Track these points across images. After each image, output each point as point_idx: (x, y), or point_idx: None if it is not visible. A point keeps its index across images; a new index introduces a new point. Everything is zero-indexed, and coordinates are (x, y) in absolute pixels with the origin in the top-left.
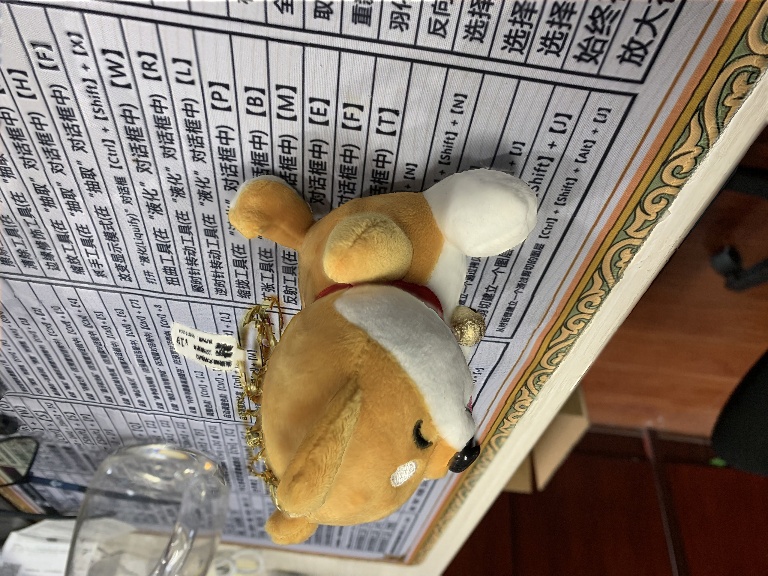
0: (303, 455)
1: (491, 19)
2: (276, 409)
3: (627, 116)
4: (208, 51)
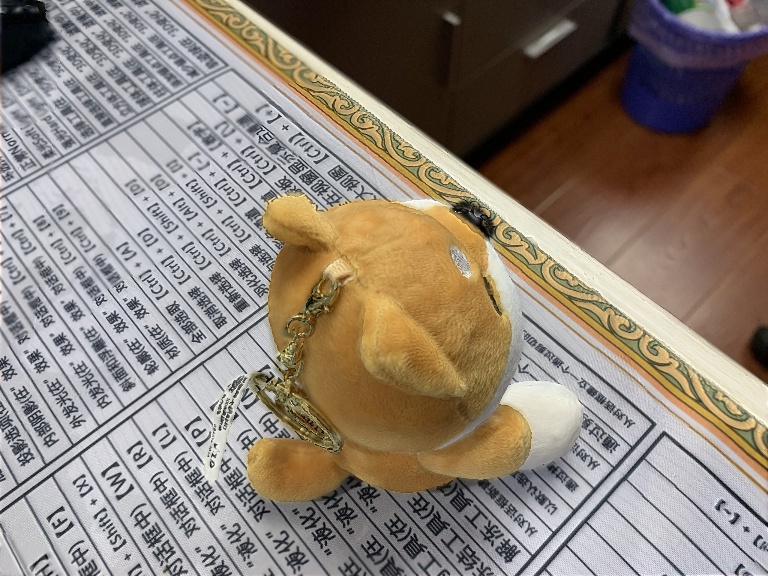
0: None
1: None
2: None
3: None
4: (172, 405)
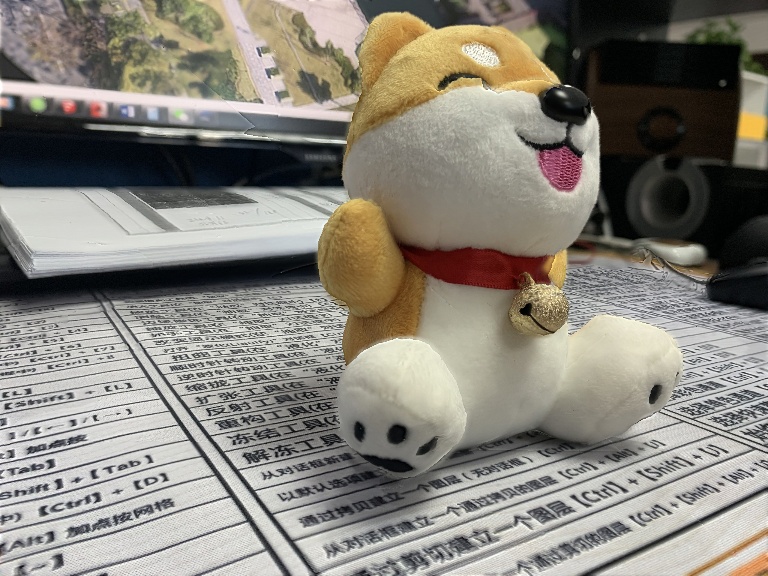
0: None
1: None
2: None
3: None
4: None
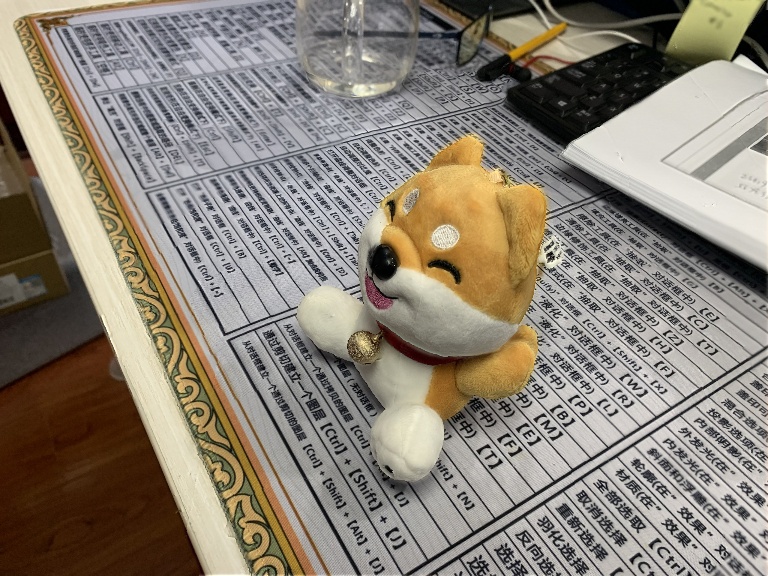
0: None
1: (505, 568)
2: None
3: None
4: (608, 429)
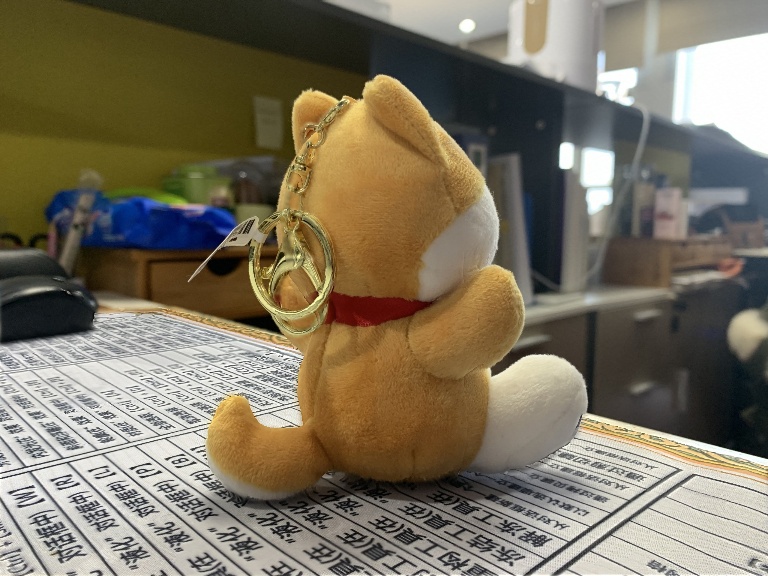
0: None
1: None
2: None
3: None
4: None
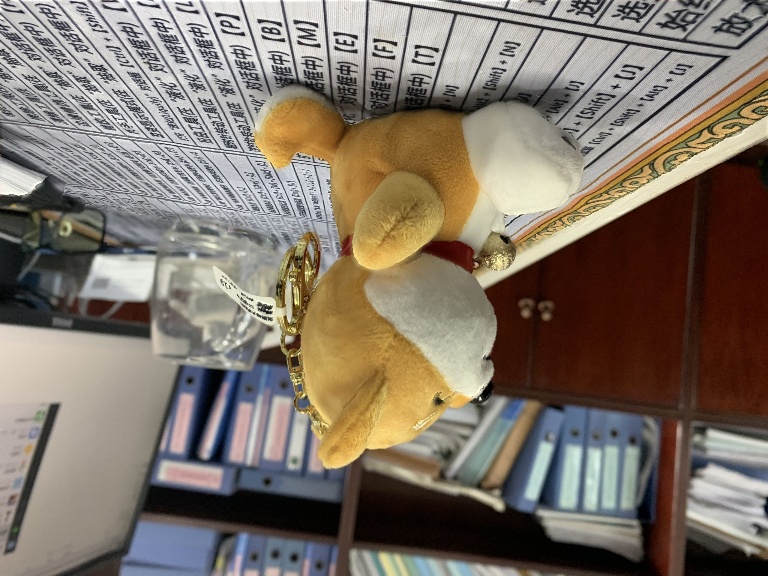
0: (338, 434)
1: None
2: (315, 375)
3: (711, 71)
4: None
